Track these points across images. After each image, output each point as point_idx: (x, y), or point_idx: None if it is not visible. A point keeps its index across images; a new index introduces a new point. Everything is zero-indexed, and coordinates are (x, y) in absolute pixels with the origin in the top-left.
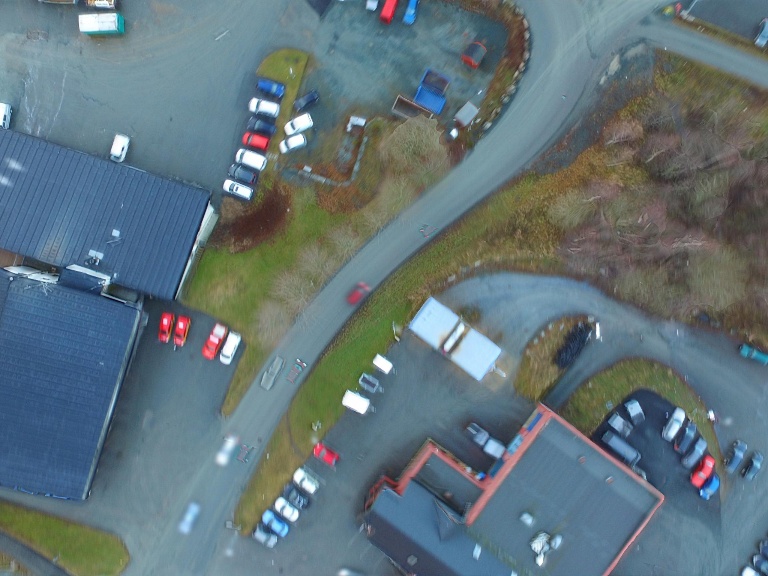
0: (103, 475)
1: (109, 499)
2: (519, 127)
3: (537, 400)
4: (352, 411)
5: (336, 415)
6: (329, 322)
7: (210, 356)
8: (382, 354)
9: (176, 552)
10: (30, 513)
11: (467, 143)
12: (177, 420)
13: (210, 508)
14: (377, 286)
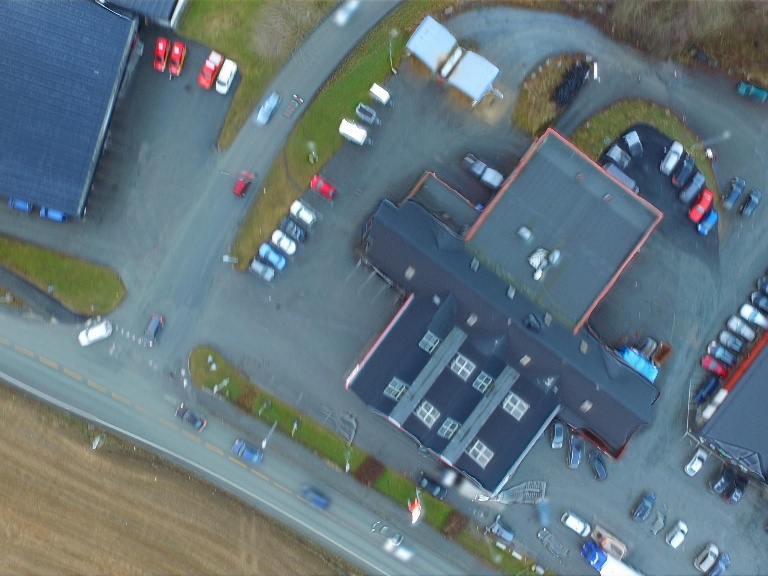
0: (99, 202)
1: (105, 232)
2: None
3: (535, 134)
4: (349, 142)
5: (333, 148)
6: (326, 59)
7: (206, 85)
8: (379, 85)
9: (172, 286)
10: (25, 246)
11: None
12: (173, 152)
13: (207, 242)
14: (374, 25)
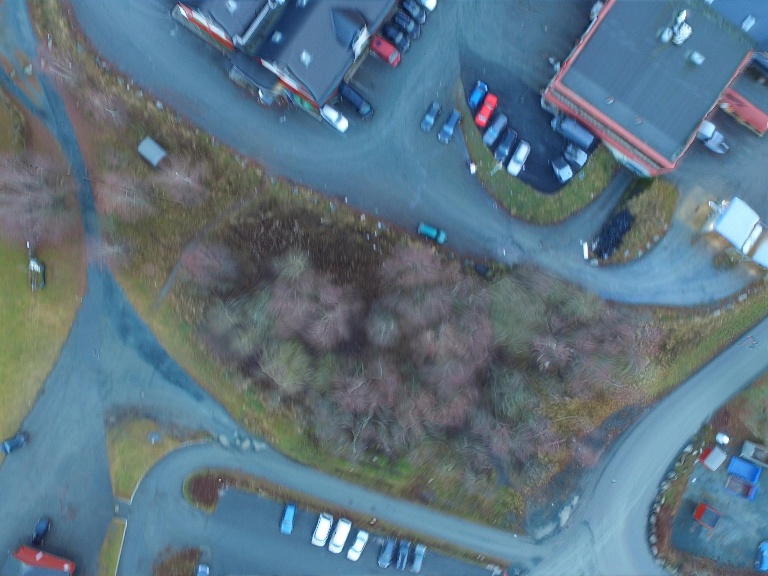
0: None
1: None
2: (657, 449)
3: (655, 178)
4: None
5: None
6: None
7: None
8: None
9: None
10: None
11: (708, 430)
12: None
13: None
14: None
